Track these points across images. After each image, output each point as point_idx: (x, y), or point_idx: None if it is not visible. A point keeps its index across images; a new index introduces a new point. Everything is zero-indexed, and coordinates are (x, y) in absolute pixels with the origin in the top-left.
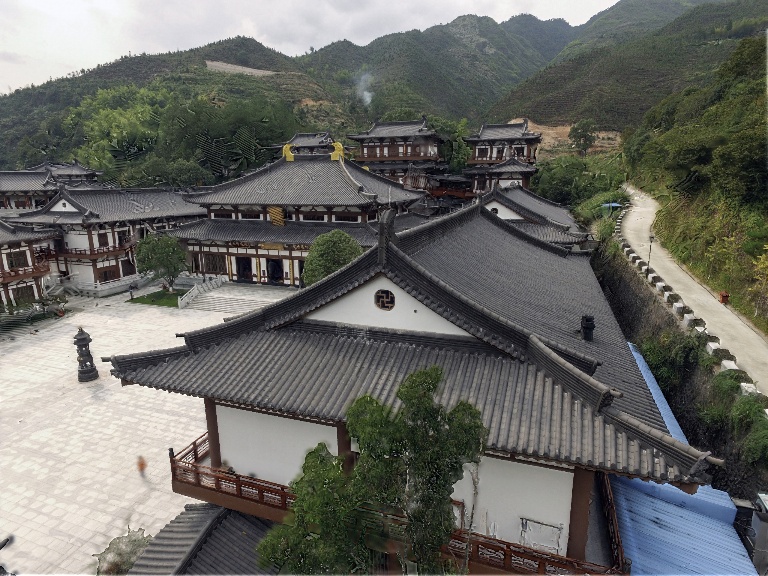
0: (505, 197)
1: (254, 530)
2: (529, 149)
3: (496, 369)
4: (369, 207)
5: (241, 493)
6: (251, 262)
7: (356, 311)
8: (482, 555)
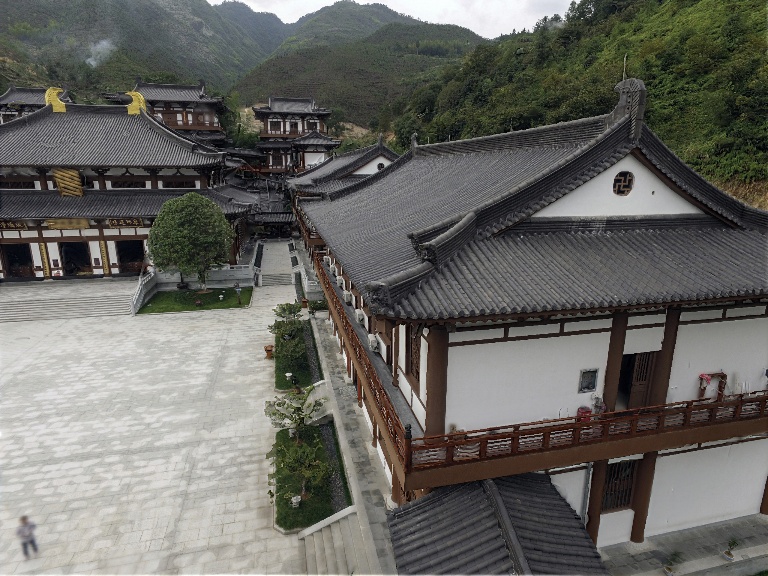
0: (391, 152)
1: (520, 494)
2: (322, 125)
3: (735, 238)
4: (211, 169)
5: (517, 449)
6: (30, 250)
7: (593, 200)
8: (766, 409)
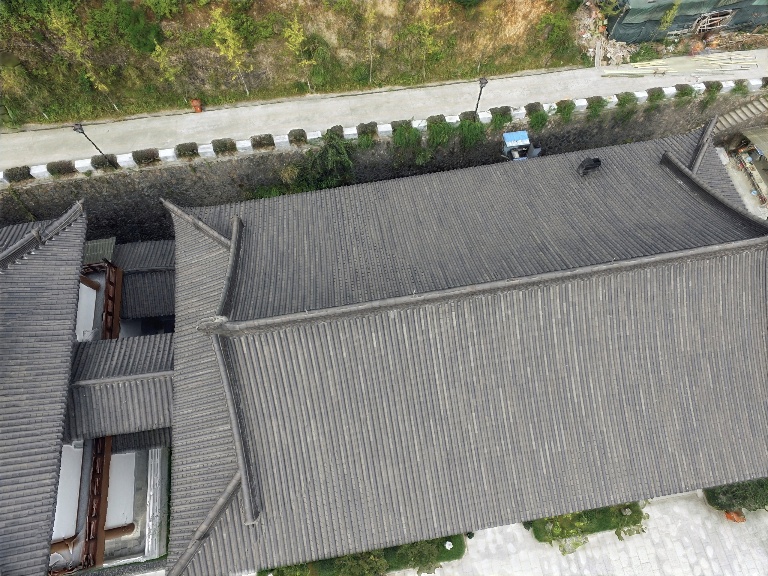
0: None
1: None
2: None
3: None
4: None
5: None
6: None
7: None
8: None
